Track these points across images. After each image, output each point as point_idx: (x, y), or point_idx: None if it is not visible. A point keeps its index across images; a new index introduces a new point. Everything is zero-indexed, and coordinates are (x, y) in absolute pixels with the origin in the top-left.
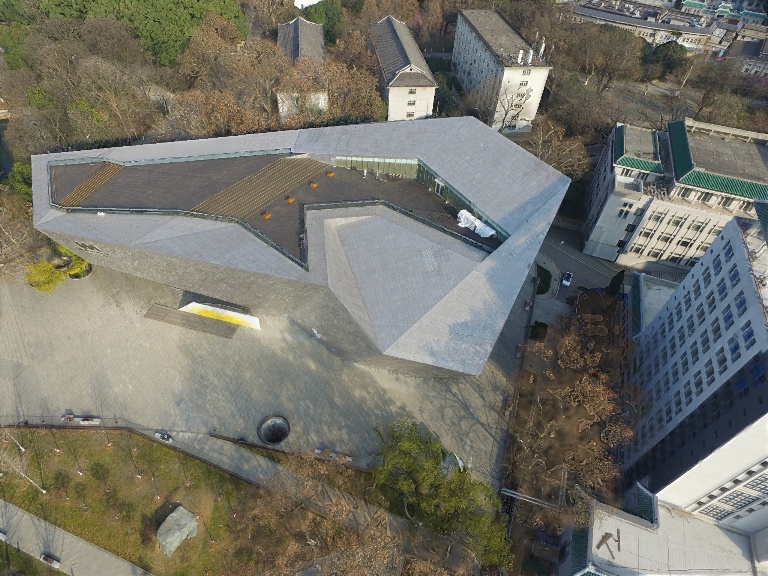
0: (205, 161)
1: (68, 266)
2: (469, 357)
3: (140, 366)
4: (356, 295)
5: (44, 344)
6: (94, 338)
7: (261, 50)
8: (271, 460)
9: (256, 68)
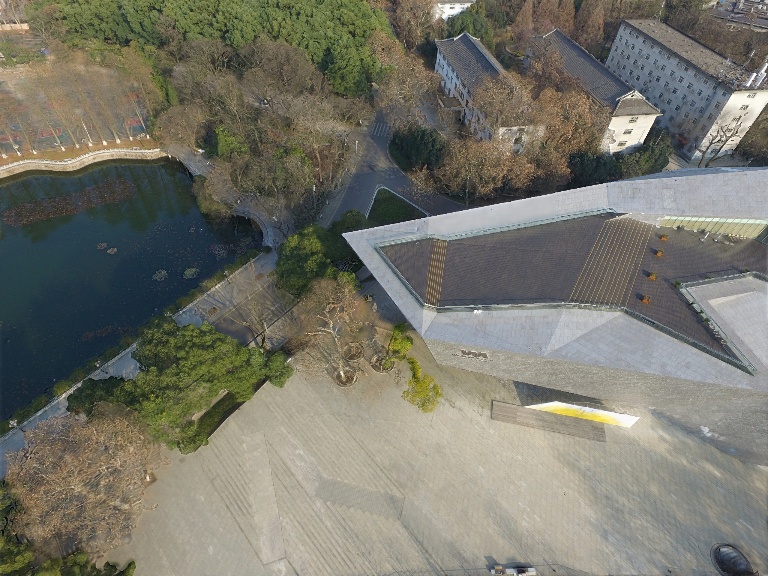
0: (528, 229)
1: (364, 355)
2: None
3: (530, 488)
4: None
5: (403, 466)
6: (455, 453)
7: (515, 85)
8: None
9: (505, 105)
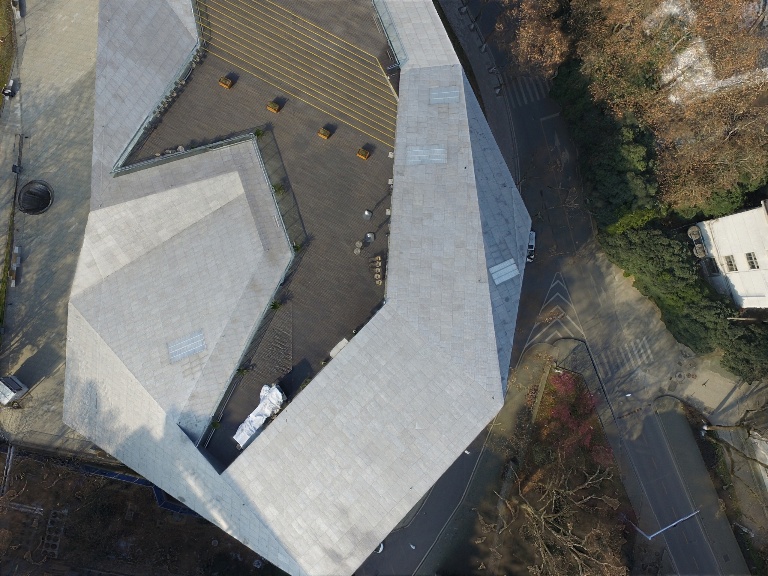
0: None
1: None
2: (77, 409)
3: (92, 25)
4: (131, 251)
5: None
6: None
7: None
8: (13, 205)
9: None
